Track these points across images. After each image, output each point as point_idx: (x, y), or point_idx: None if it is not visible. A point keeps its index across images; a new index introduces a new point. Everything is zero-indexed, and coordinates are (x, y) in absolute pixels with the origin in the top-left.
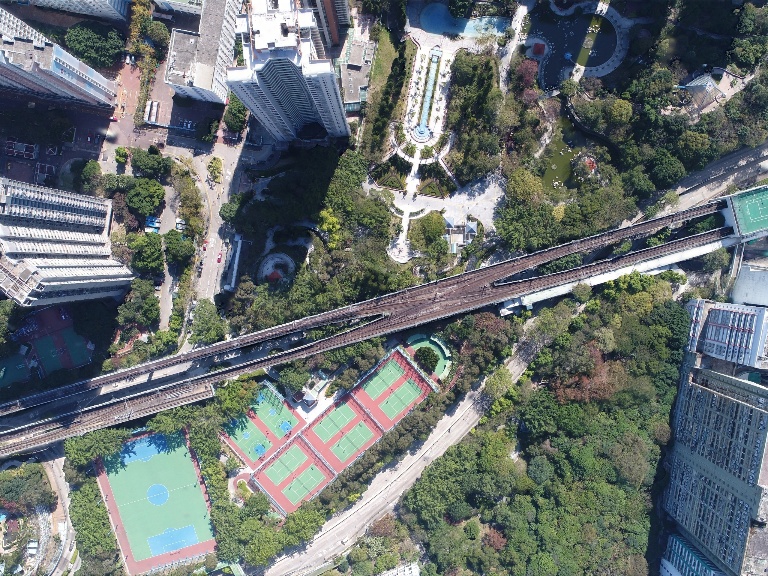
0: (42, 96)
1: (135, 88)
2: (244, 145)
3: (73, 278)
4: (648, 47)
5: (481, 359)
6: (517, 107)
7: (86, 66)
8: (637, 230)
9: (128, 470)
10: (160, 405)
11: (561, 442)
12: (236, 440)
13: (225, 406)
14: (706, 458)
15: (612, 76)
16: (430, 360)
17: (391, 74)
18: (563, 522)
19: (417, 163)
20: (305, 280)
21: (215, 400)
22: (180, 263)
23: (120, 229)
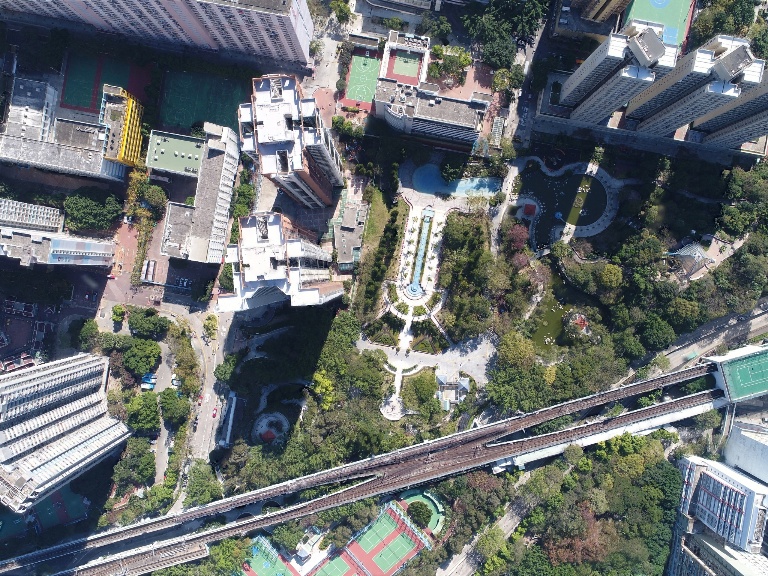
0: None
1: (132, 247)
2: None
3: (68, 468)
4: (637, 211)
5: (473, 520)
6: (508, 270)
7: (83, 243)
8: (628, 391)
9: None
10: (155, 563)
11: None
12: None
13: (219, 566)
14: None
15: (602, 236)
16: (423, 516)
17: (383, 240)
18: None
19: (410, 320)
20: (298, 442)
21: (209, 559)
22: None
23: (117, 384)
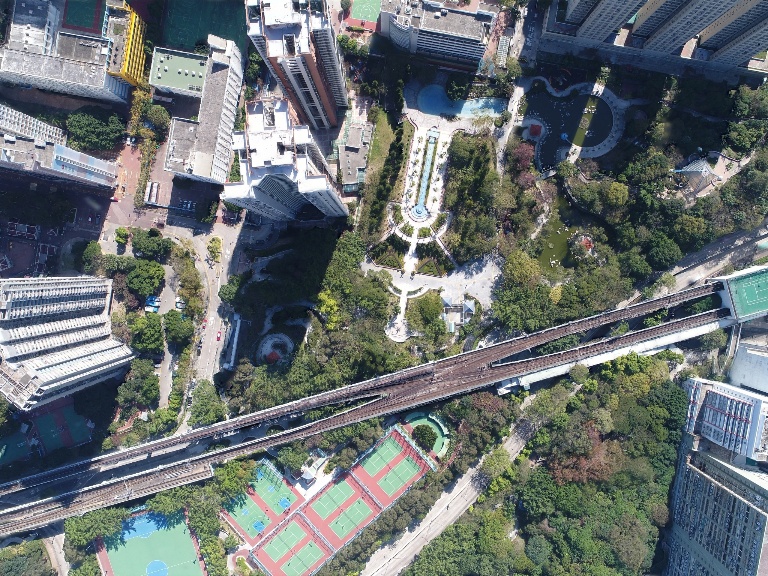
0: (44, 178)
1: (135, 169)
2: (243, 225)
3: (73, 374)
4: (644, 130)
5: (479, 440)
6: (514, 189)
7: (87, 156)
8: (634, 311)
9: (128, 546)
10: (159, 485)
11: (559, 523)
12: (235, 517)
13: (224, 486)
14: (704, 547)
15: (608, 157)
16: (428, 439)
17: (388, 158)
18: None
19: (415, 242)
20: (303, 362)
21: (214, 480)
22: (180, 342)
23: (120, 307)
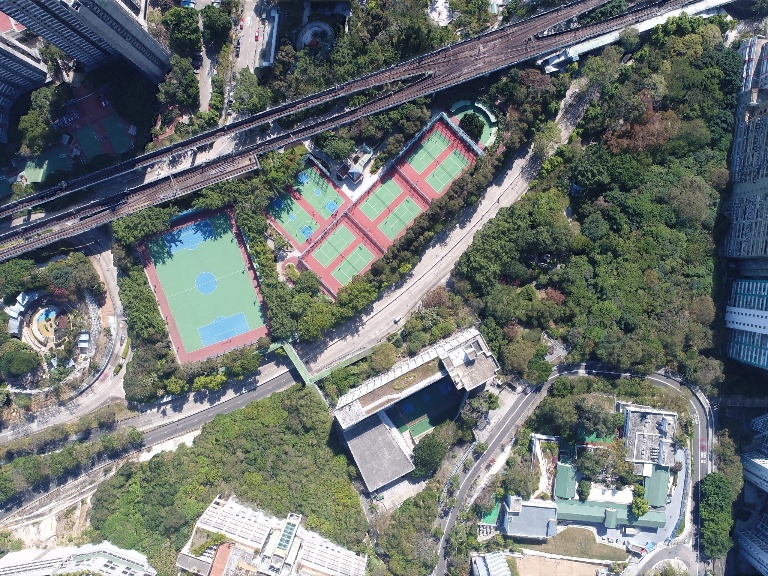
0: None
1: None
2: None
3: (117, 7)
4: None
5: (529, 114)
6: None
7: None
8: None
9: (175, 259)
10: (205, 181)
11: (615, 195)
12: (282, 223)
13: (271, 176)
14: None
15: None
16: (476, 125)
17: None
18: (623, 270)
19: None
20: (346, 41)
21: (260, 173)
22: (218, 40)
23: (156, 14)
